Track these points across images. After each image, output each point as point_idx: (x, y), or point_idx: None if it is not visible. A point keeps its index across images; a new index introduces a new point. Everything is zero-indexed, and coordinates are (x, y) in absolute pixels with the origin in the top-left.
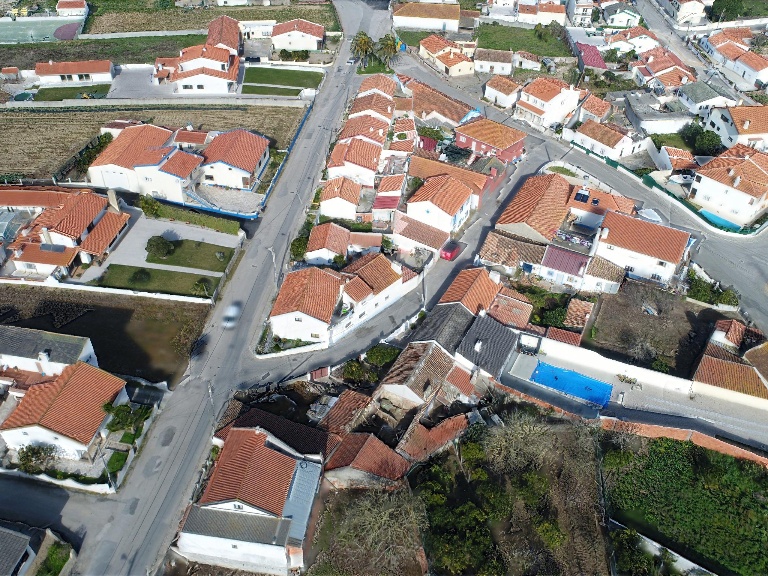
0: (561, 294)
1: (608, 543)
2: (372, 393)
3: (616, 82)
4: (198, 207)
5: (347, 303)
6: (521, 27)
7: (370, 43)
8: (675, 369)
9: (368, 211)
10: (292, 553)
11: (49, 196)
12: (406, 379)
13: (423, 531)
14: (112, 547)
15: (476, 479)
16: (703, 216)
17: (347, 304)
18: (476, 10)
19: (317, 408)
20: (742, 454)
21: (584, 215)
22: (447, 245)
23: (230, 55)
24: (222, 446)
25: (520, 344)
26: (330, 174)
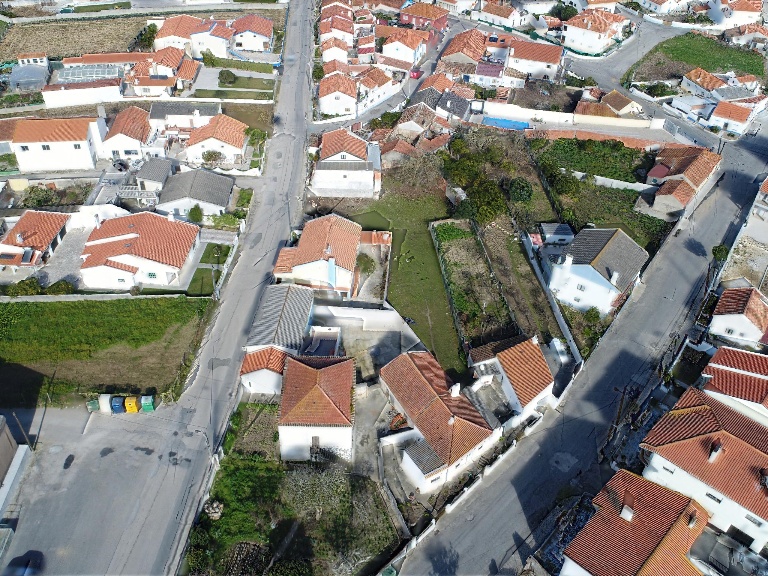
0: None
1: (538, 171)
2: (393, 128)
3: None
4: None
5: (363, 92)
6: None
7: None
8: None
9: None
10: (376, 178)
11: (136, 55)
12: (411, 119)
13: (442, 168)
14: (272, 192)
15: (463, 153)
16: (571, 49)
17: (363, 93)
18: None
19: None
20: (604, 138)
21: (496, 51)
22: (413, 69)
23: None
24: (317, 150)
25: (471, 109)
26: (322, 39)
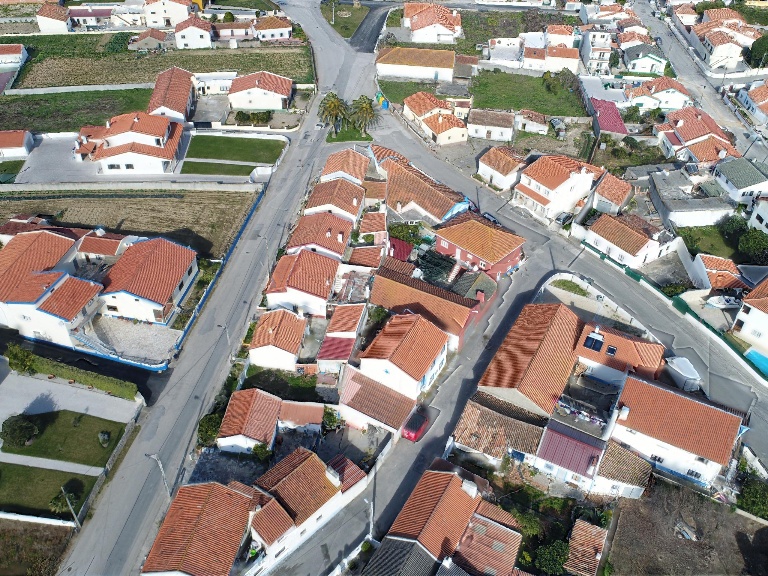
0: (563, 500)
1: None
2: None
3: (638, 150)
4: (91, 353)
5: (257, 540)
6: (527, 74)
7: (341, 107)
8: None
9: (314, 357)
10: None
11: None
12: None
13: None
14: None
15: None
16: (753, 365)
17: (257, 541)
18: (476, 52)
19: None
20: None
21: (596, 366)
22: (411, 419)
23: (170, 124)
24: None
25: None
26: (269, 301)
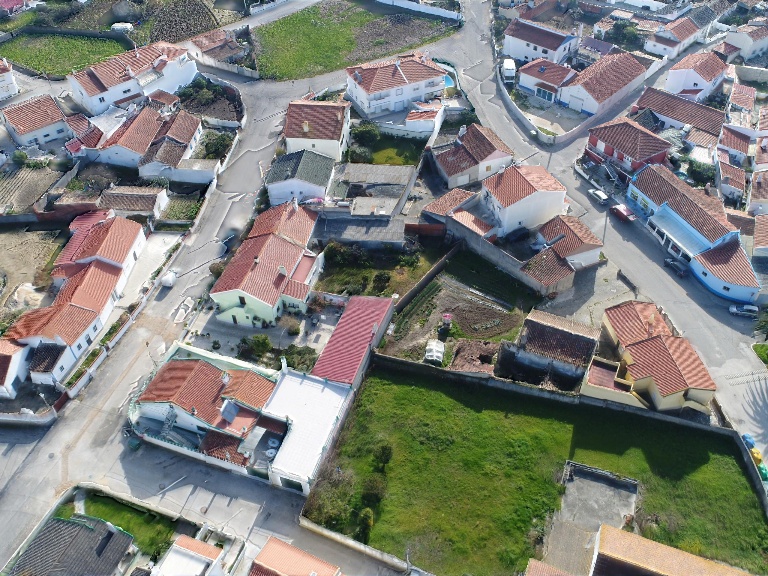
0: None
1: None
2: None
3: None
4: None
5: None
6: None
7: None
8: (556, 15)
9: (758, 104)
10: None
11: None
12: None
13: None
14: None
15: None
16: None
17: None
18: None
19: (767, 5)
20: None
21: None
22: None
23: None
24: None
25: None
26: None
